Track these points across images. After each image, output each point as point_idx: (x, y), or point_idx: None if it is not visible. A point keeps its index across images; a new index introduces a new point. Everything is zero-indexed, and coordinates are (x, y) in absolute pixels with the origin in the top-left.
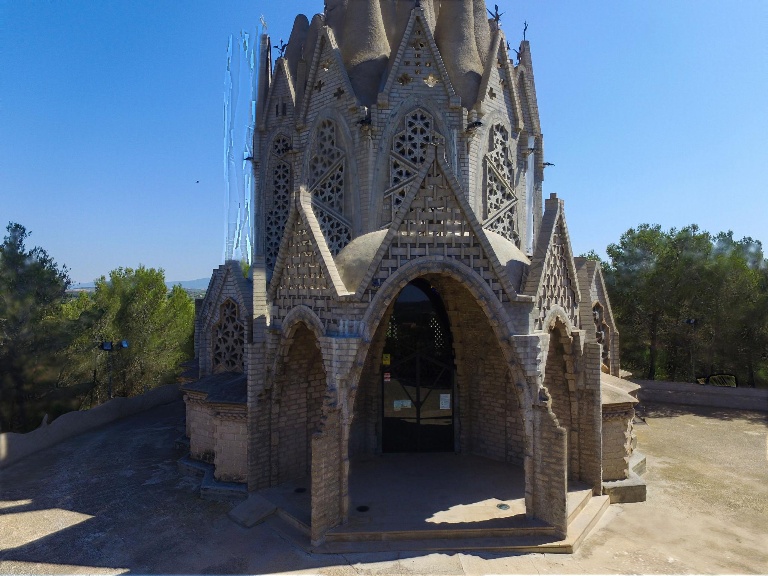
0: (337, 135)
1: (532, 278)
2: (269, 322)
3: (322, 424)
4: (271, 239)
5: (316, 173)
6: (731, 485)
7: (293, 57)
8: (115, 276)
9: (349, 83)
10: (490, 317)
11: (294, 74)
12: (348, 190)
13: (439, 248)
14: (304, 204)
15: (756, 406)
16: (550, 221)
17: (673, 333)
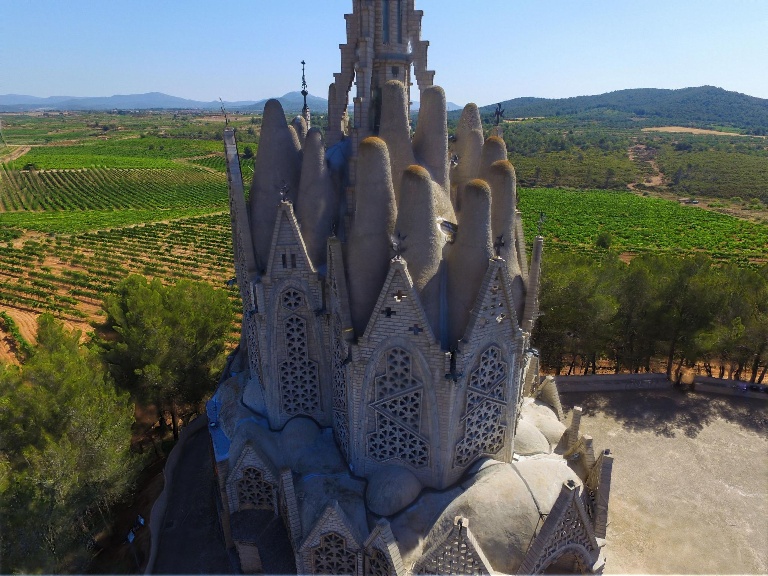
0: (413, 366)
1: (600, 522)
2: None
3: None
4: (288, 387)
5: (384, 389)
6: (631, 522)
7: (276, 168)
8: (12, 379)
9: (428, 323)
10: (582, 563)
11: None
12: (425, 414)
13: (563, 541)
14: (468, 533)
15: (600, 389)
16: (608, 475)
17: (553, 333)
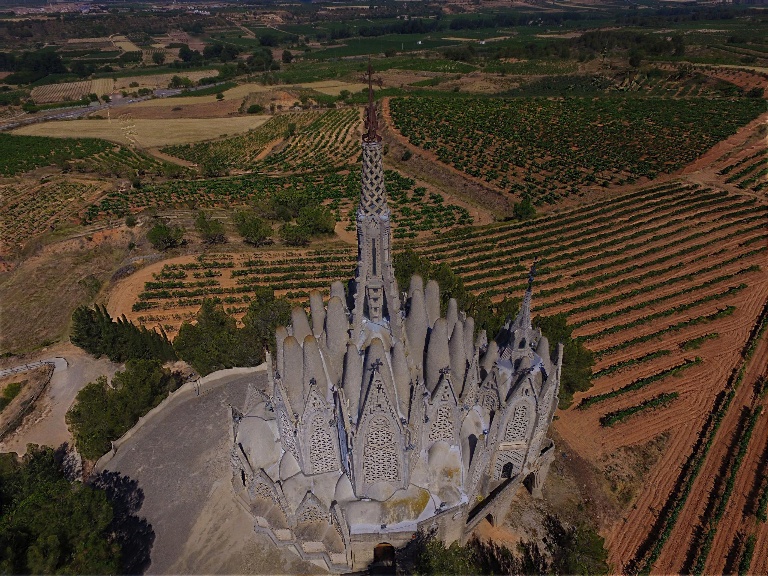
0: None
1: None
2: None
3: None
4: None
5: None
6: (260, 573)
7: None
8: None
9: None
10: None
11: None
12: None
13: None
14: (249, 388)
15: None
16: None
17: None
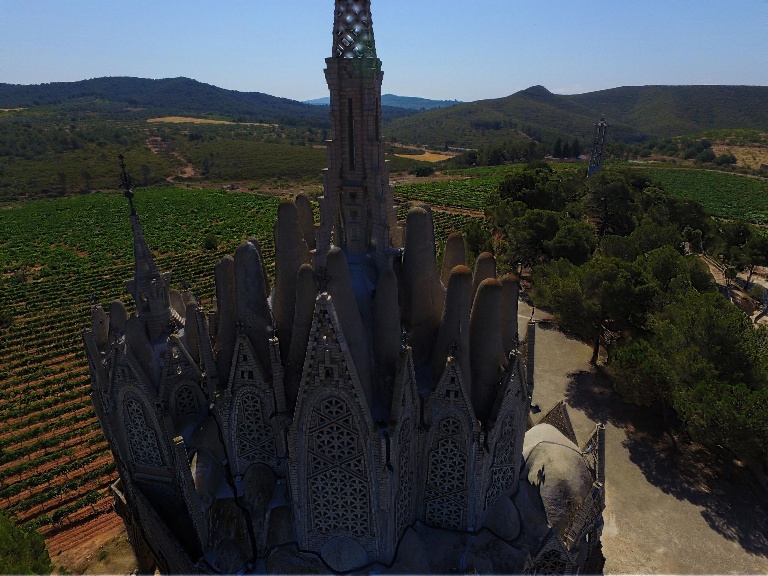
0: None
1: None
2: None
3: (602, 554)
4: (398, 515)
5: None
6: None
7: (358, 316)
8: None
9: None
10: None
11: None
12: None
13: None
14: None
15: None
16: None
17: None
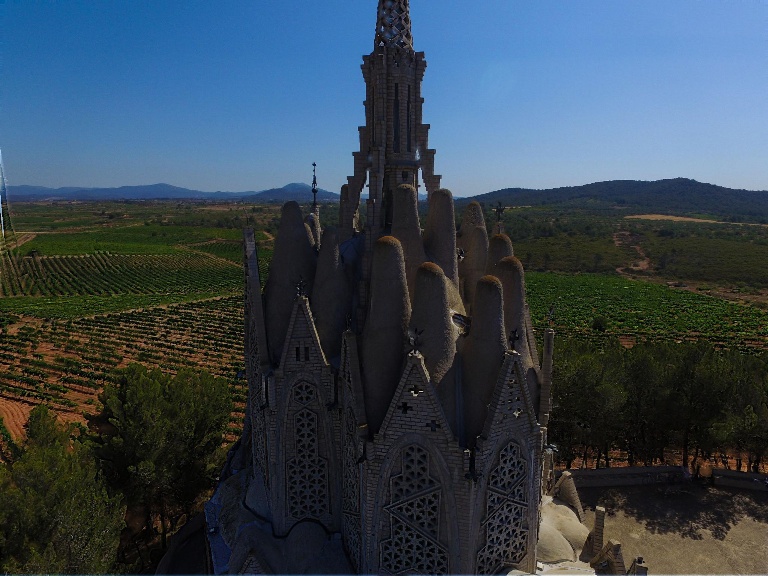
0: (430, 464)
1: None
2: None
3: None
4: (295, 488)
5: (400, 490)
6: None
7: (292, 263)
8: (1, 480)
9: (445, 418)
10: None
11: None
12: (443, 518)
13: None
14: None
15: (616, 483)
16: None
17: (562, 422)
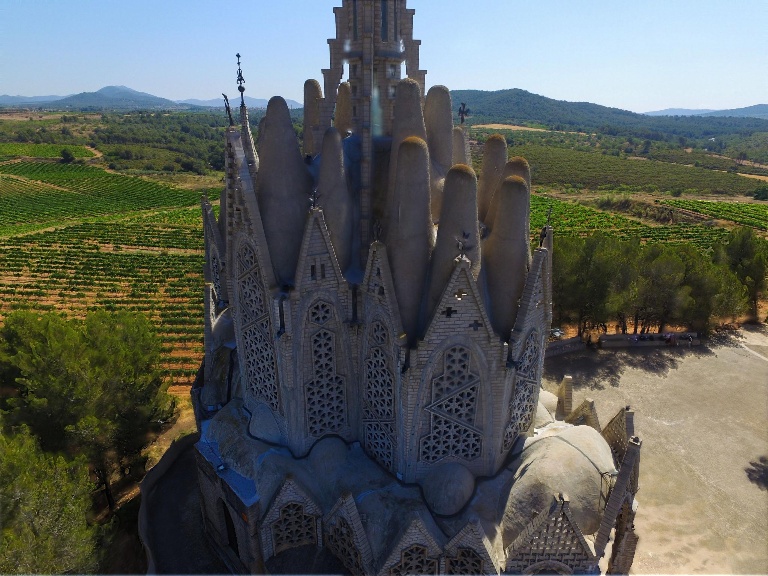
0: (471, 361)
1: None
2: (504, 570)
3: None
4: (314, 409)
5: (440, 389)
6: None
7: (288, 172)
8: None
9: None
10: (628, 508)
11: (294, 198)
12: (480, 406)
13: None
14: None
15: None
16: (631, 427)
17: None
